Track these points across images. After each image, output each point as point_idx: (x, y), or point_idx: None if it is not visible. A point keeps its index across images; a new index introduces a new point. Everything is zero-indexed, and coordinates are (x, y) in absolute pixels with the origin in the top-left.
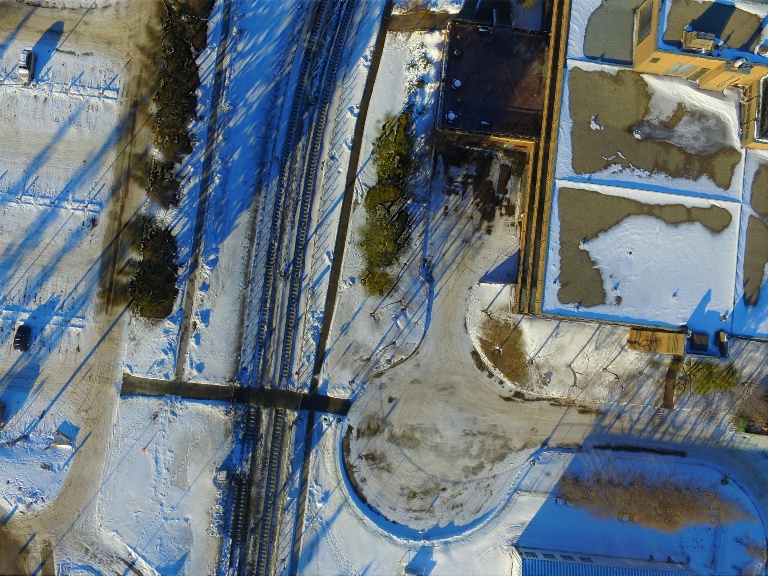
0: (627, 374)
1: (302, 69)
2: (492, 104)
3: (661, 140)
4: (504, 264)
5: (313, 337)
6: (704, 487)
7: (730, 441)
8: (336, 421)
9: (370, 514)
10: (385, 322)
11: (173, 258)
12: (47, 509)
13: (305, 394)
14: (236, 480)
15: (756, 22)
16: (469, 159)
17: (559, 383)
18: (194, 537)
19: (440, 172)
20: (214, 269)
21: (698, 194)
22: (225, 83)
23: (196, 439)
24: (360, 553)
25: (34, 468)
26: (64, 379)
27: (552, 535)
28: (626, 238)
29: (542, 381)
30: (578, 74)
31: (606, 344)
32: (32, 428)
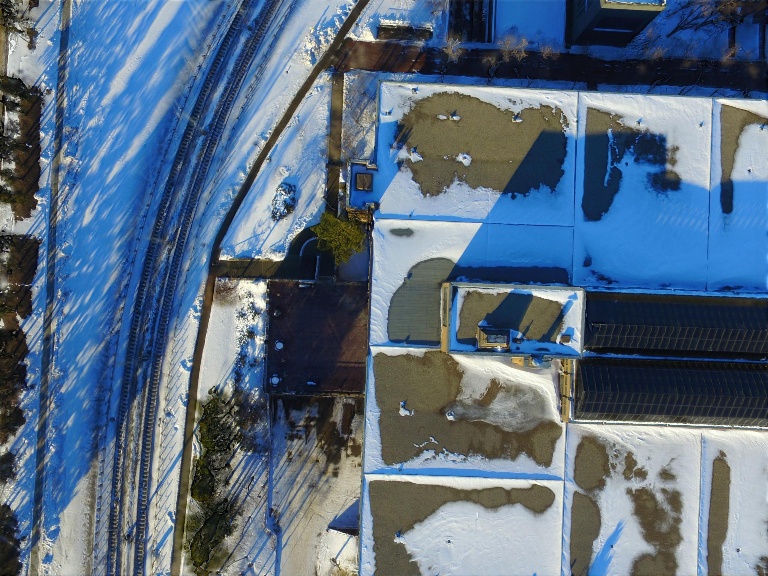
0: None
1: (133, 323)
2: (319, 361)
3: (476, 420)
4: (353, 506)
5: None
6: None
7: None
8: None
9: None
10: None
11: (14, 532)
12: None
13: None
14: None
15: (557, 309)
16: (310, 401)
17: None
18: None
19: (281, 417)
20: (56, 539)
21: (517, 475)
22: (53, 349)
23: None
24: None
25: None
26: None
27: None
28: (443, 527)
29: None
30: (383, 360)
31: None
32: None
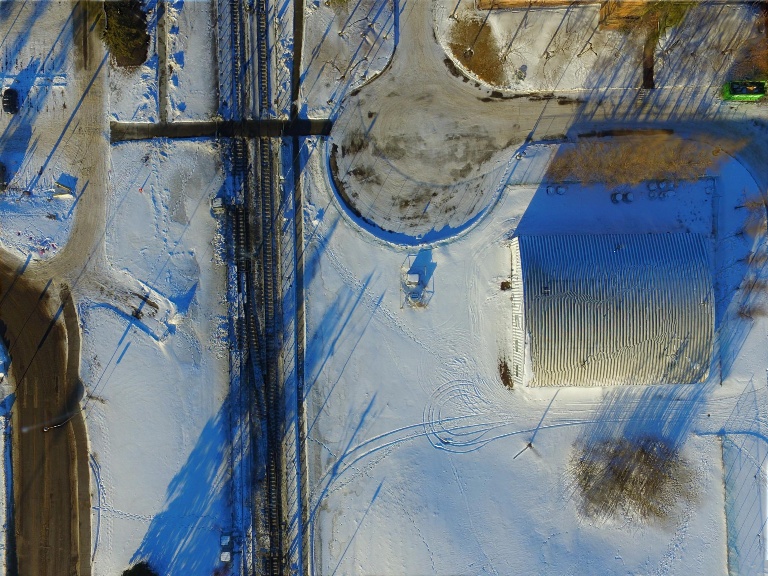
0: (603, 57)
1: None
2: None
3: None
4: None
5: (286, 65)
6: (695, 160)
7: (717, 113)
8: (320, 139)
9: (366, 226)
10: (354, 40)
11: (140, 6)
12: (59, 255)
13: (286, 121)
14: (232, 211)
15: None
16: None
17: (535, 76)
18: (201, 268)
19: None
20: (181, 12)
21: None
22: None
23: (188, 175)
24: (361, 264)
25: (41, 219)
26: (55, 135)
27: (547, 224)
28: None
29: (518, 76)
30: None
31: (577, 28)
32: (33, 184)
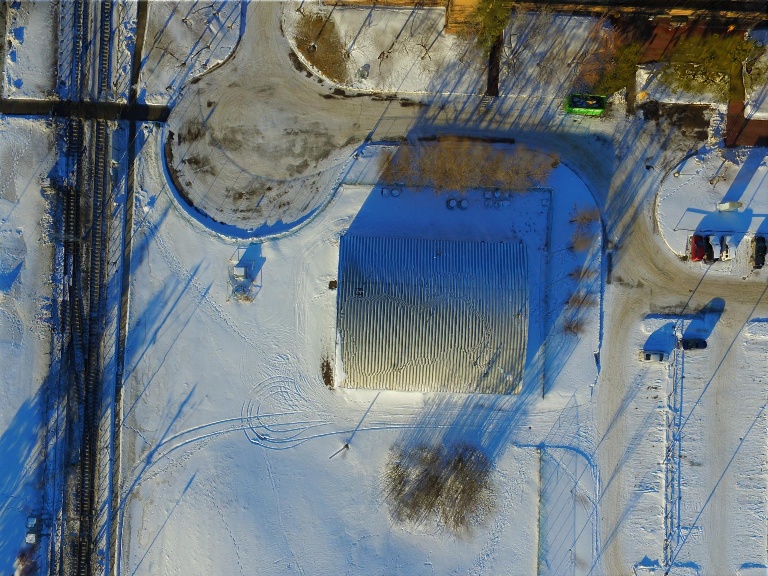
0: (447, 62)
1: None
2: None
3: None
4: None
5: (127, 48)
6: (534, 171)
7: (560, 125)
8: (154, 125)
9: (197, 216)
10: (197, 27)
11: None
12: None
13: (124, 105)
14: (64, 192)
15: None
16: None
17: (378, 76)
18: (27, 247)
19: None
20: None
21: None
22: None
23: (20, 153)
24: (190, 253)
25: None
26: None
27: (380, 226)
28: None
29: (360, 75)
30: None
31: (421, 30)
32: None
